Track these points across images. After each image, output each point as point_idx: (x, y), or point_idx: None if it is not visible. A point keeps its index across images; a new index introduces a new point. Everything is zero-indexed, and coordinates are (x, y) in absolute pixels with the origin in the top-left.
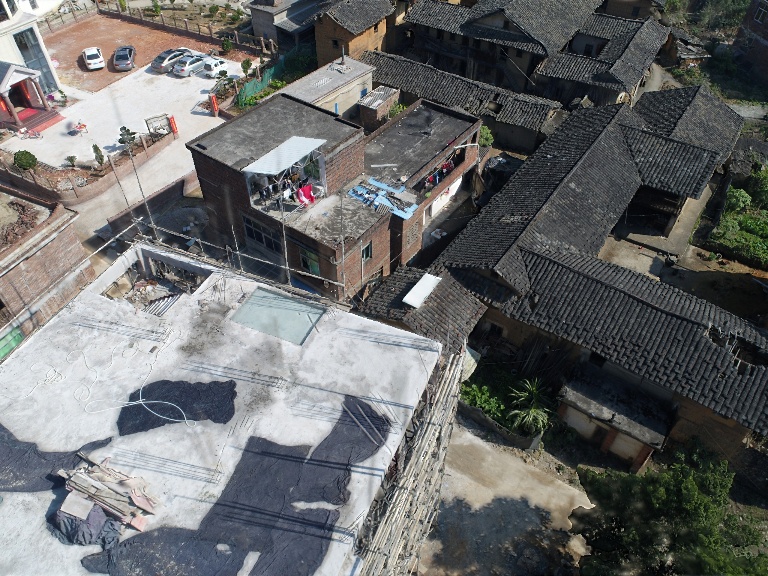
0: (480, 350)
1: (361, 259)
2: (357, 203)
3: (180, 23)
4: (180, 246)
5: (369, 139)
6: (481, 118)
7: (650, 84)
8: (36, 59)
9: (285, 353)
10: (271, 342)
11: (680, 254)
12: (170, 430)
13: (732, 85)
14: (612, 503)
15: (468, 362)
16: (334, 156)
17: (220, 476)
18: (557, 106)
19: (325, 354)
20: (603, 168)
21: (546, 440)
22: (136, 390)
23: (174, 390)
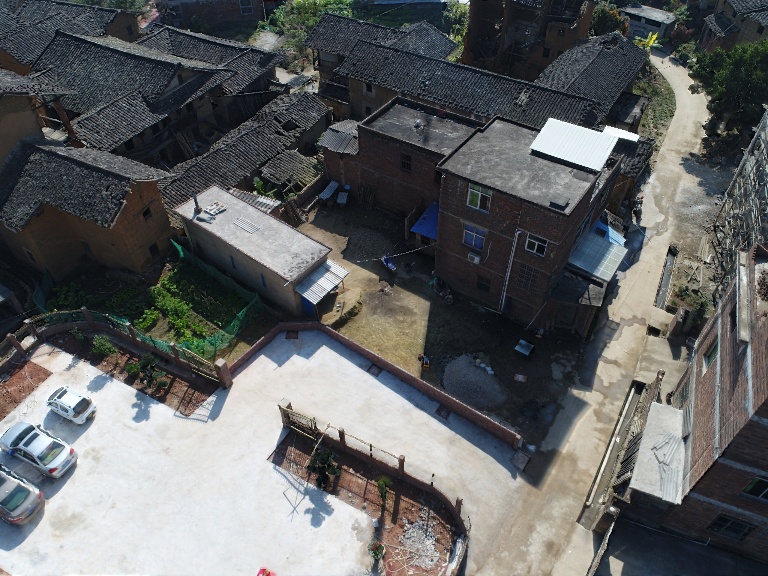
0: None
1: None
2: None
3: None
4: (518, 373)
5: None
6: None
7: None
8: None
9: None
10: None
11: None
12: None
13: (226, 36)
14: None
15: None
16: None
17: None
18: None
19: None
20: None
21: None
22: None
23: None
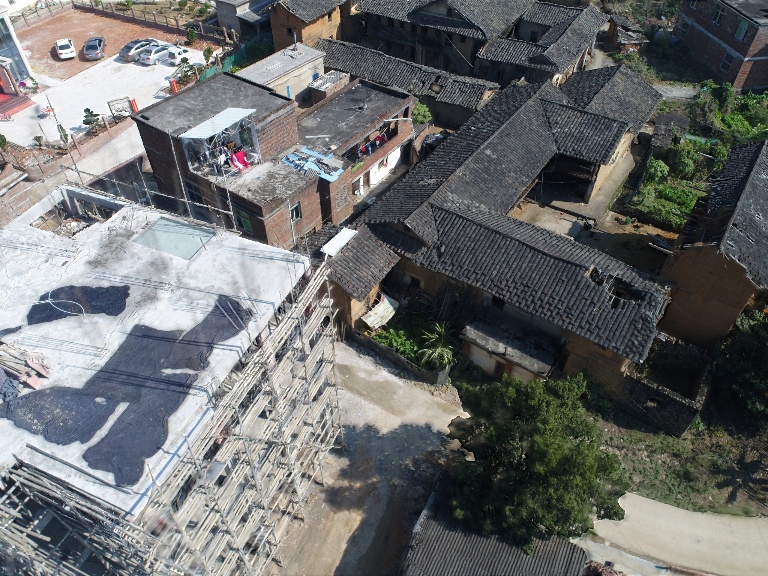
0: (398, 299)
1: (290, 218)
2: (289, 169)
3: (150, 16)
4: None
5: (306, 114)
6: (424, 99)
7: (591, 68)
8: (8, 48)
9: (175, 265)
10: (165, 257)
11: (598, 218)
12: (70, 321)
13: (668, 68)
14: (480, 409)
15: (386, 309)
16: (265, 125)
17: (106, 352)
18: (494, 86)
19: (208, 266)
20: (520, 137)
21: (453, 376)
22: (46, 293)
23: (78, 292)
